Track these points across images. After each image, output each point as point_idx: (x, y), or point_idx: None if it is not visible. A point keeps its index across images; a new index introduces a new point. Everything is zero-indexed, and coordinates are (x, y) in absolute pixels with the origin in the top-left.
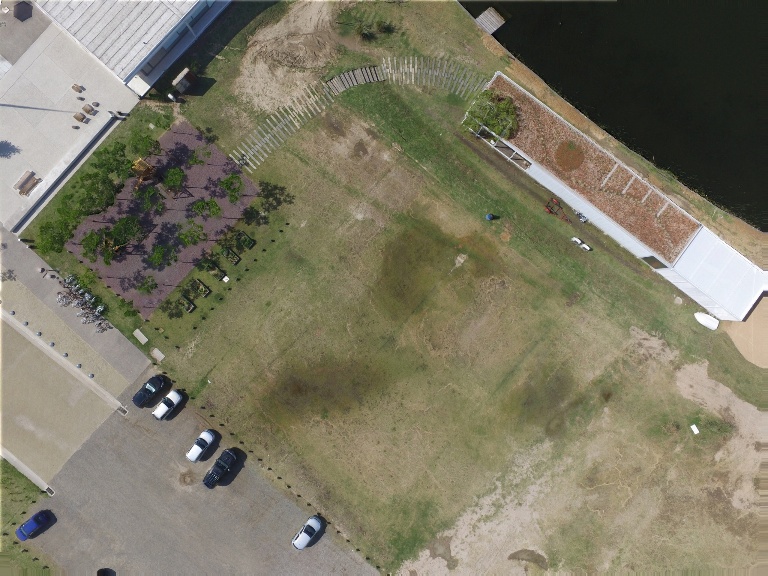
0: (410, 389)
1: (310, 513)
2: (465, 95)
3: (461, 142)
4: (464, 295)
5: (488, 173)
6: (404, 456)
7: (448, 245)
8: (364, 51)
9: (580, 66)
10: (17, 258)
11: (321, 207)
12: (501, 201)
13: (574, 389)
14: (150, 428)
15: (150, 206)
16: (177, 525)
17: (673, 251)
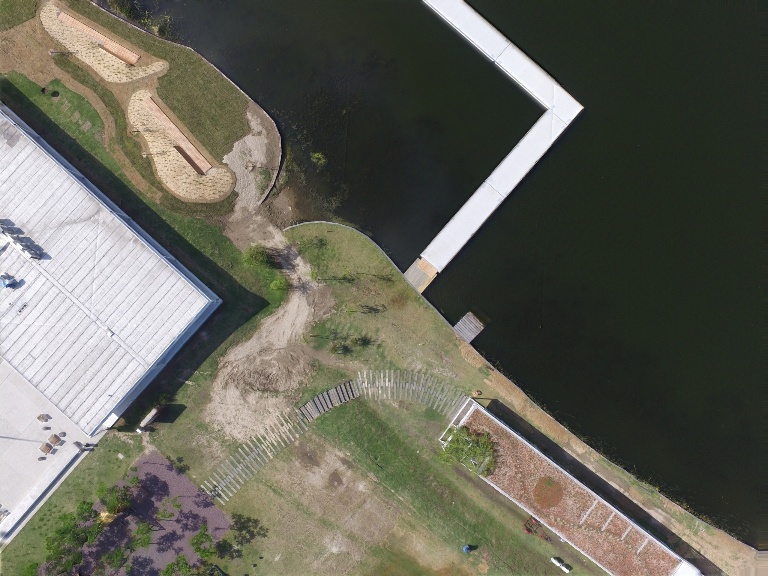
0: None
1: None
2: (443, 410)
3: None
4: None
5: (466, 491)
6: None
7: None
8: (339, 365)
9: (561, 372)
10: None
11: (295, 540)
12: (479, 525)
13: None
14: None
15: (118, 564)
16: None
17: None
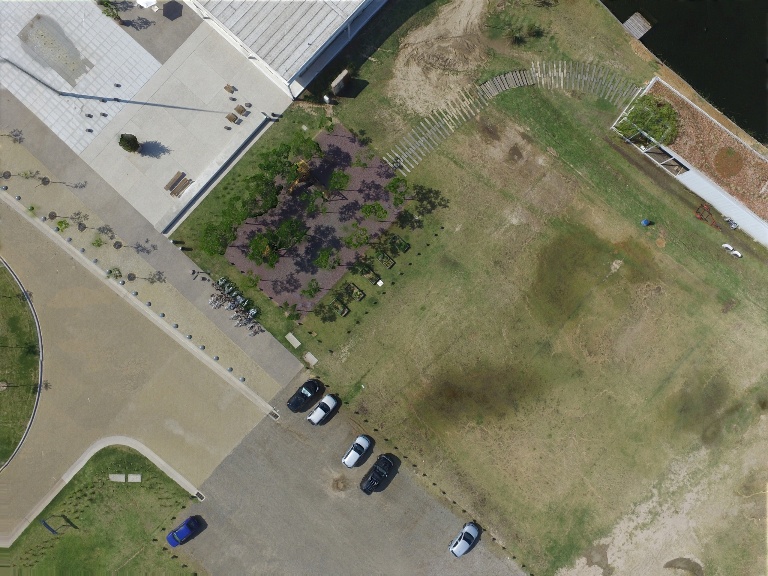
0: (566, 395)
1: (465, 520)
2: (614, 100)
3: (610, 147)
4: (620, 301)
5: (638, 178)
6: (560, 463)
7: (603, 251)
8: (513, 55)
9: (726, 72)
10: (167, 260)
11: (476, 211)
12: (653, 207)
13: (730, 396)
14: (302, 433)
15: None
16: (330, 531)
17: None
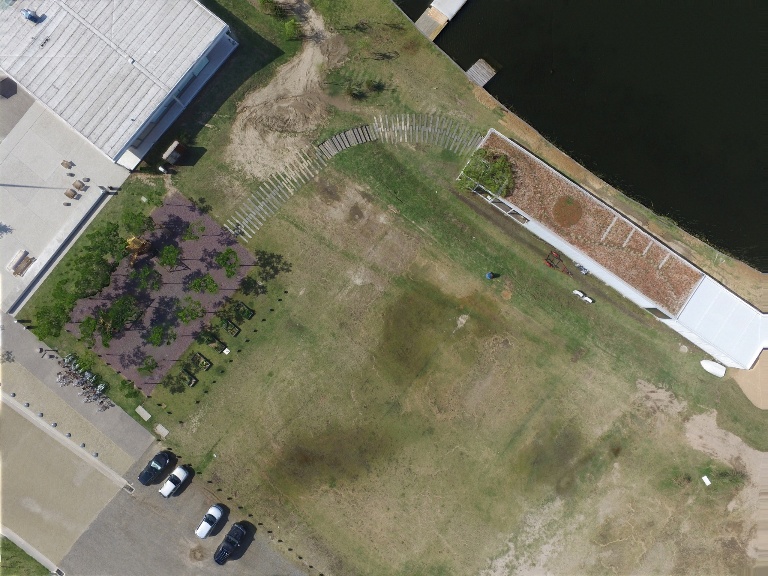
0: (418, 453)
1: None
2: (459, 150)
3: (457, 198)
4: (468, 356)
5: (486, 229)
6: (415, 521)
7: (449, 306)
8: (355, 111)
9: (574, 114)
10: (15, 339)
11: (319, 274)
12: (500, 257)
13: (583, 446)
14: (157, 505)
15: (146, 285)
16: None
17: (676, 303)
